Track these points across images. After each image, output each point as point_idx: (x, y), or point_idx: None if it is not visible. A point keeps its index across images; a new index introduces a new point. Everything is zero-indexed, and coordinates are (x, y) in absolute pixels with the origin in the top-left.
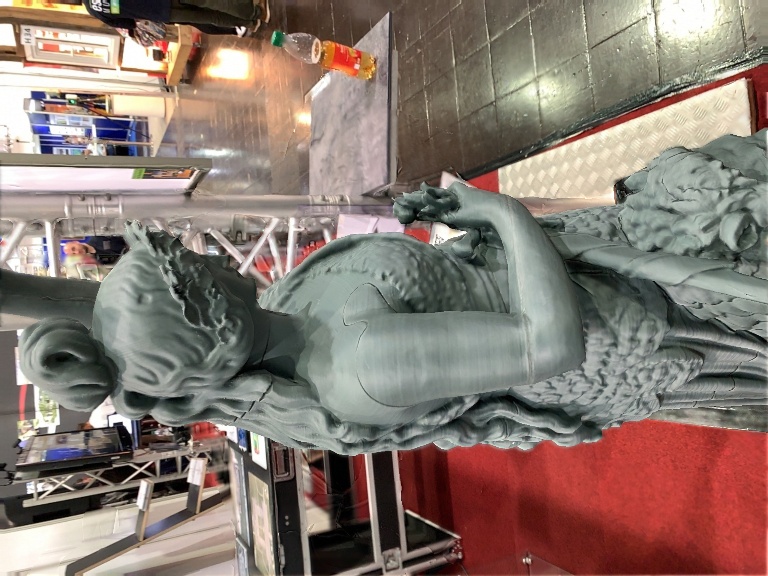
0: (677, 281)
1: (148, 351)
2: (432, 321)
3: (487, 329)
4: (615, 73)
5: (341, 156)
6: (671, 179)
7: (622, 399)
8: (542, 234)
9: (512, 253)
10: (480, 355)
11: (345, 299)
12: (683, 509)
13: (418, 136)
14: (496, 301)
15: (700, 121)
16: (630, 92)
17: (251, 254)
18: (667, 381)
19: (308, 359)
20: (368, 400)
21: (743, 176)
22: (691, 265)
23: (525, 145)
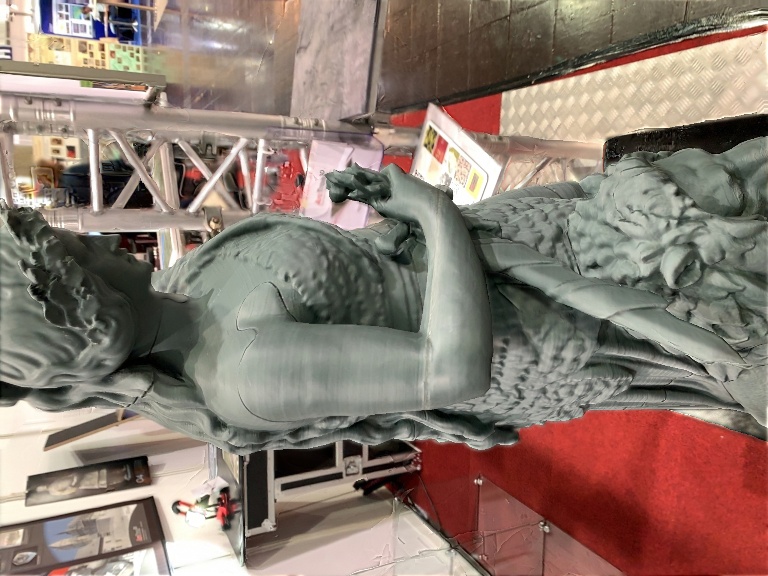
0: (602, 316)
1: (9, 348)
2: (327, 338)
3: (384, 353)
4: (640, 1)
5: (324, 72)
6: (622, 195)
7: (540, 410)
8: (467, 246)
9: (432, 263)
10: (372, 381)
11: (243, 297)
12: (628, 459)
13: (405, 62)
14: (414, 306)
15: (717, 72)
16: (651, 26)
17: (216, 174)
18: (590, 396)
19: (196, 359)
20: (249, 415)
21: (696, 207)
22: (620, 300)
23: (534, 70)
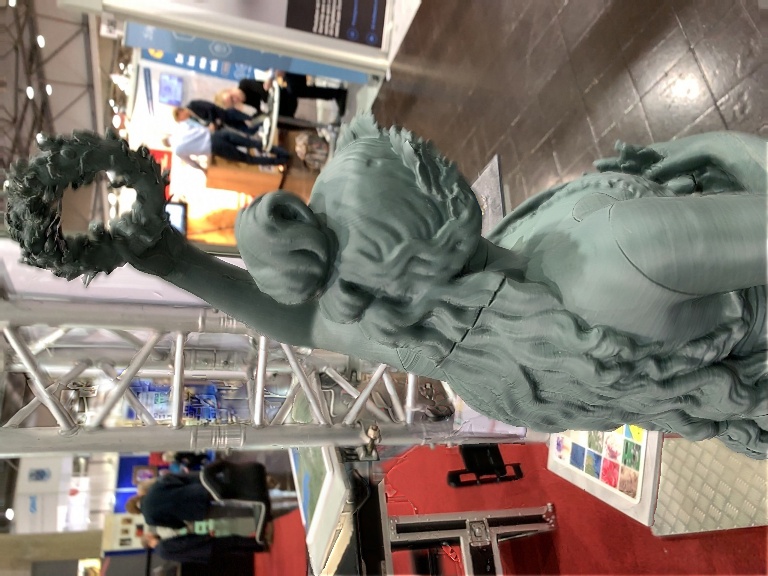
0: None
1: (376, 217)
2: None
3: (761, 198)
4: None
5: None
6: None
7: None
8: None
9: (750, 162)
10: (763, 219)
11: (570, 209)
12: None
13: None
14: None
15: None
16: None
17: (372, 381)
18: None
19: (540, 261)
20: (633, 274)
21: None
22: None
23: None
